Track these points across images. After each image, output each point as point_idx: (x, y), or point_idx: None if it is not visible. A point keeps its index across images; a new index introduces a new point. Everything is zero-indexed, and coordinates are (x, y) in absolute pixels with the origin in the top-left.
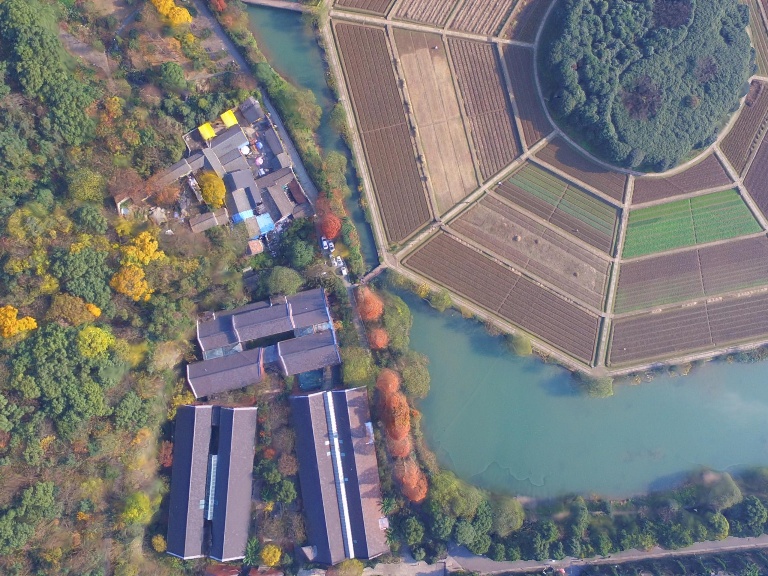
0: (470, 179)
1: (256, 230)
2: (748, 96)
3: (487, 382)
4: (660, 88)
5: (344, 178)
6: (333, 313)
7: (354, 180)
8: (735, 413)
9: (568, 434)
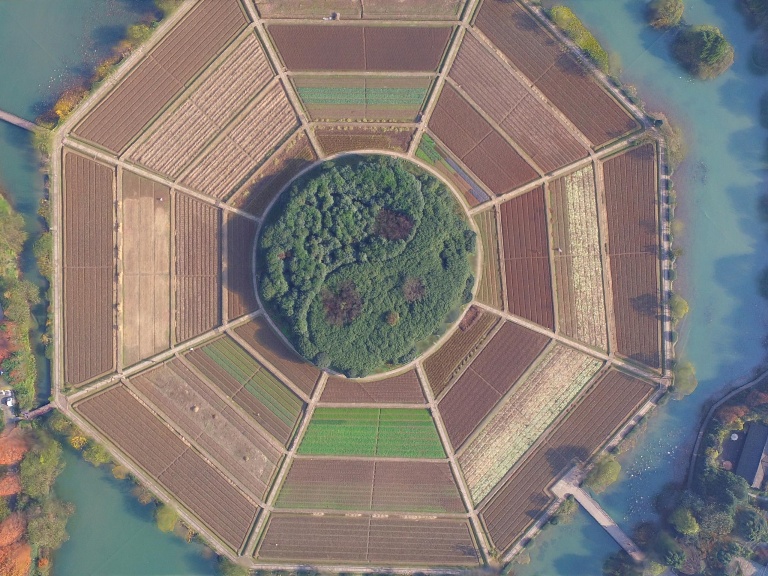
0: (163, 338)
1: None
2: (463, 320)
3: (131, 545)
4: (363, 297)
5: (27, 311)
6: None
7: (46, 312)
8: None
9: None
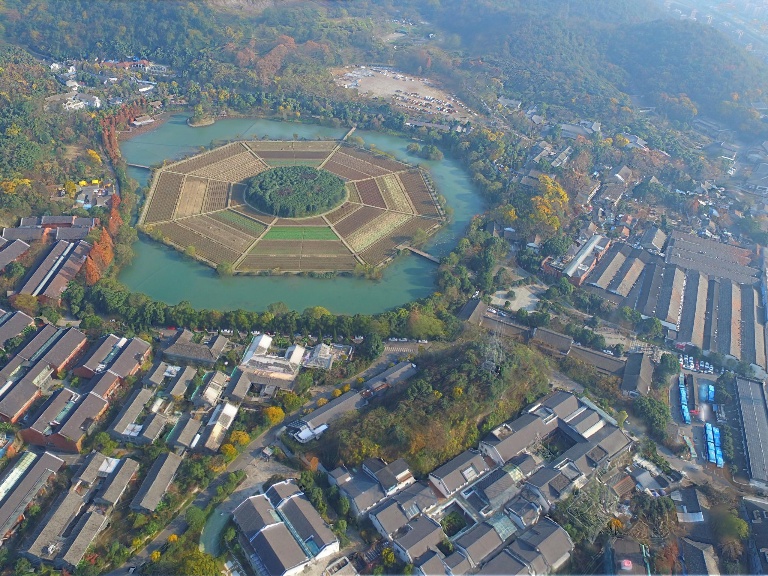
0: (197, 211)
1: (81, 206)
2: (343, 205)
3: None
4: None
5: None
6: (97, 226)
7: None
8: (308, 301)
9: (201, 291)
